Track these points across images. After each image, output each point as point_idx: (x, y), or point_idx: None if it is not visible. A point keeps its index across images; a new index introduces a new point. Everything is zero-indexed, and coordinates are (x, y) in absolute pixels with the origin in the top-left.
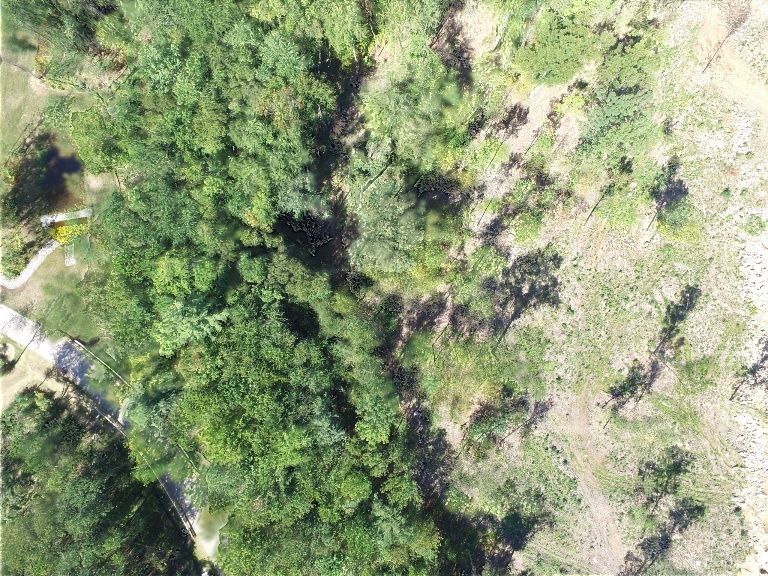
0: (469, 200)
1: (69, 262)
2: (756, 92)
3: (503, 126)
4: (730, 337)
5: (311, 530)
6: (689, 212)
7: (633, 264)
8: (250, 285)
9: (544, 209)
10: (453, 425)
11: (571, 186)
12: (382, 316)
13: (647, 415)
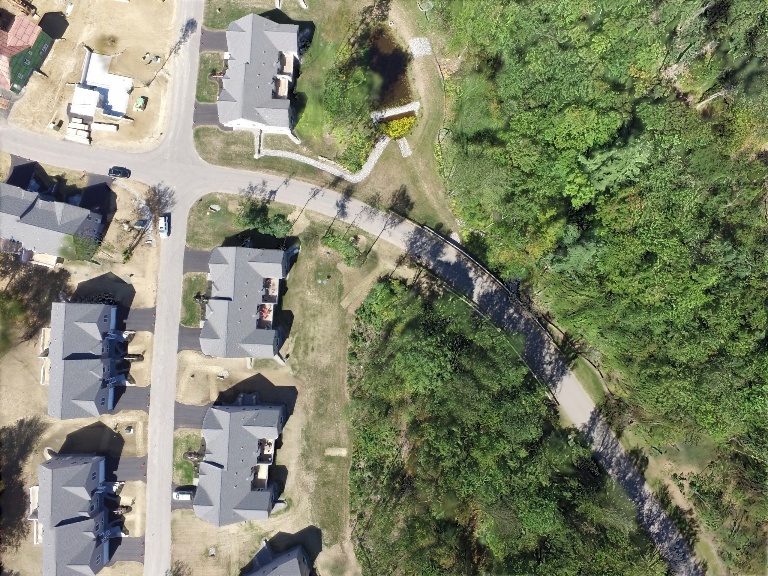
0: None
1: (405, 153)
2: None
3: None
4: None
5: (727, 363)
6: None
7: None
8: (652, 132)
9: None
10: None
11: None
12: None
13: None
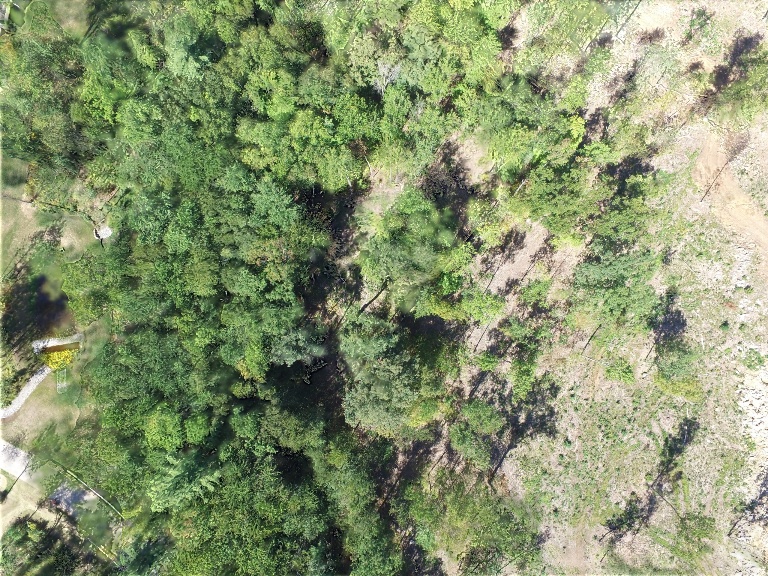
0: (465, 326)
1: (61, 389)
2: (755, 223)
3: (499, 251)
4: (728, 472)
5: None
6: (687, 344)
7: (631, 394)
8: (243, 440)
9: (541, 337)
10: (449, 554)
11: (568, 314)
12: (377, 444)
13: (645, 548)
